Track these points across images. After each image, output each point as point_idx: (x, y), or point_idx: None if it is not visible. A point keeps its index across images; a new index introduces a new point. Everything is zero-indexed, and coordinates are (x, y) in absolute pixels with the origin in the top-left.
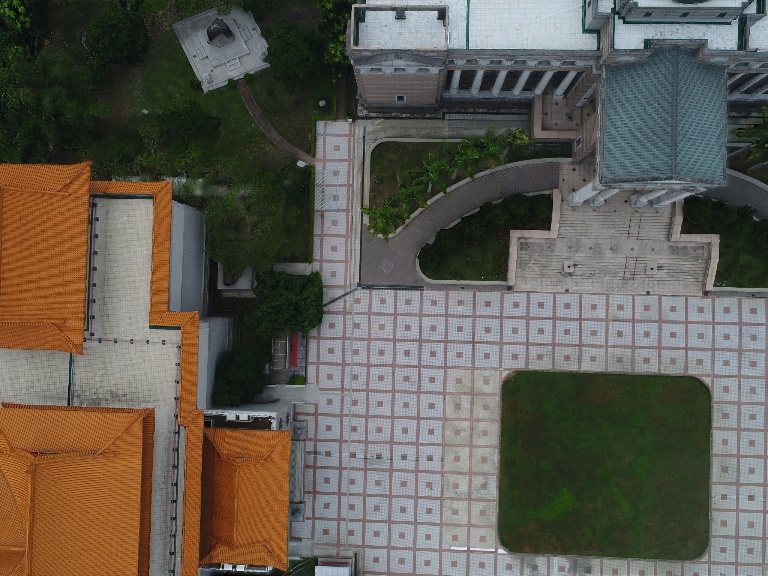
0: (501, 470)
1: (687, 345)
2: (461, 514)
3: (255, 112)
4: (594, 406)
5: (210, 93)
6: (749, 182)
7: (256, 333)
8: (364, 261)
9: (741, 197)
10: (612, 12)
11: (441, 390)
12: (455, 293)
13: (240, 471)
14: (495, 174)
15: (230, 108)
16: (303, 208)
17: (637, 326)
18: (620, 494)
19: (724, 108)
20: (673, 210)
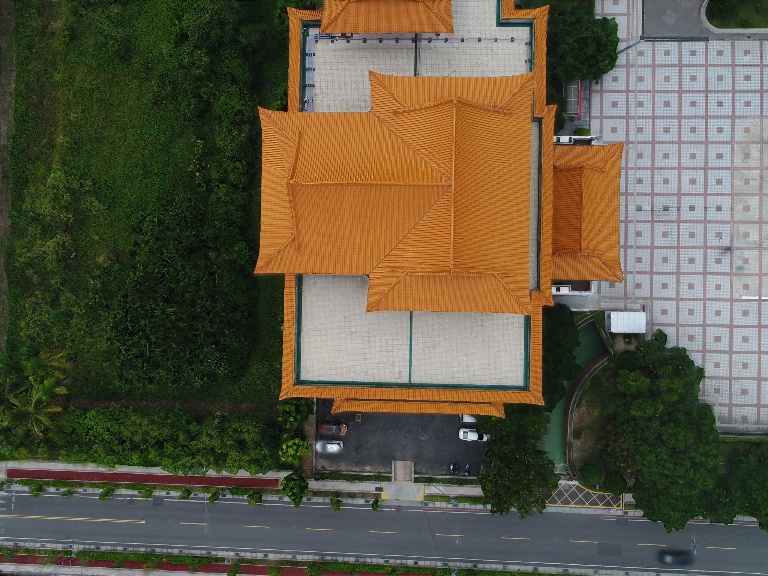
0: None
1: None
2: (752, 263)
3: None
4: None
5: None
6: None
7: (556, 72)
8: (647, 13)
9: None
10: None
11: (729, 140)
12: (741, 43)
13: (584, 174)
14: None
15: None
16: None
17: None
18: None
19: None
20: None
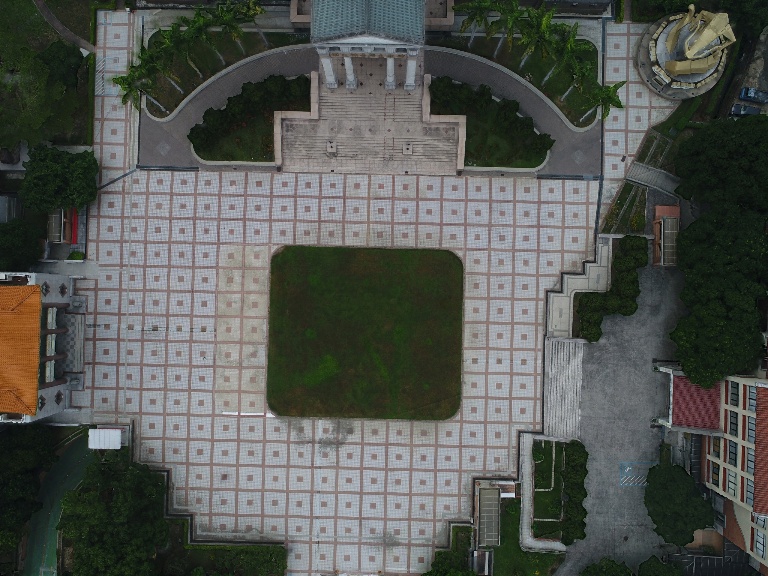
0: (270, 339)
1: (442, 221)
2: (232, 381)
3: (38, 2)
4: (356, 278)
5: None
6: (495, 68)
7: (26, 205)
8: (142, 144)
9: (488, 82)
10: None
11: (214, 265)
12: (228, 174)
13: None
14: (262, 60)
15: None
16: (84, 93)
17: (396, 203)
18: (379, 359)
19: None
20: (423, 92)
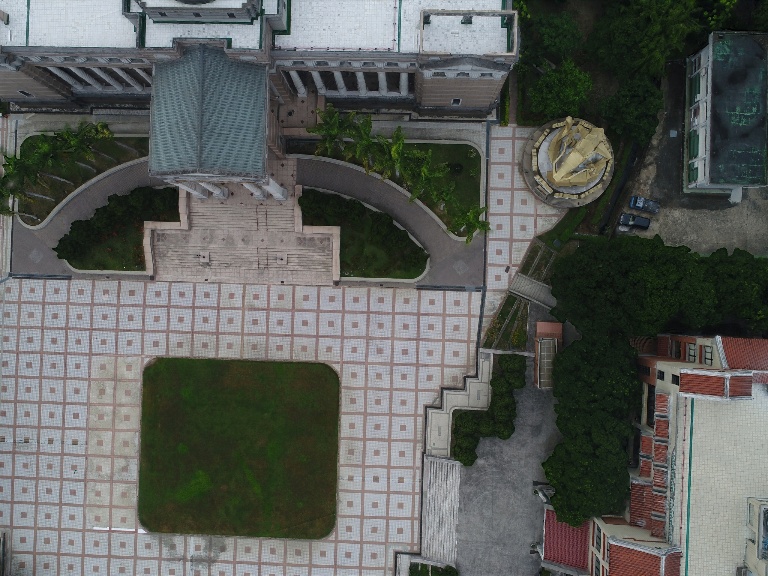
0: (141, 453)
1: (318, 333)
2: (103, 495)
3: None
4: (229, 391)
5: None
6: (372, 176)
7: None
8: (15, 251)
9: (365, 190)
10: (143, 12)
11: (86, 376)
12: (101, 282)
13: None
14: (132, 167)
15: None
16: None
17: (271, 315)
18: (252, 476)
19: (264, 104)
20: None
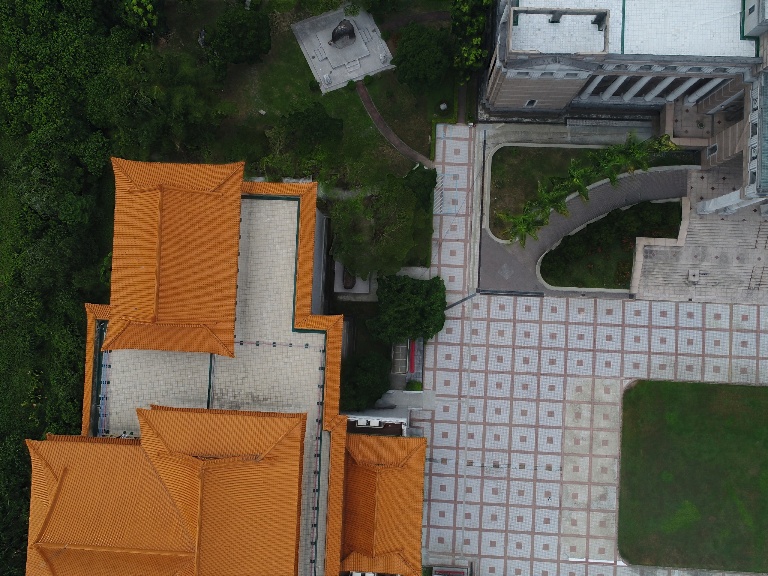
0: (621, 481)
1: None
2: (580, 525)
3: (374, 114)
4: (717, 417)
5: (328, 94)
6: None
7: (380, 338)
8: (483, 266)
9: None
10: None
11: (561, 398)
12: (576, 300)
13: (379, 478)
14: (620, 181)
15: (348, 110)
16: None
17: (762, 337)
18: (743, 507)
19: None
20: None
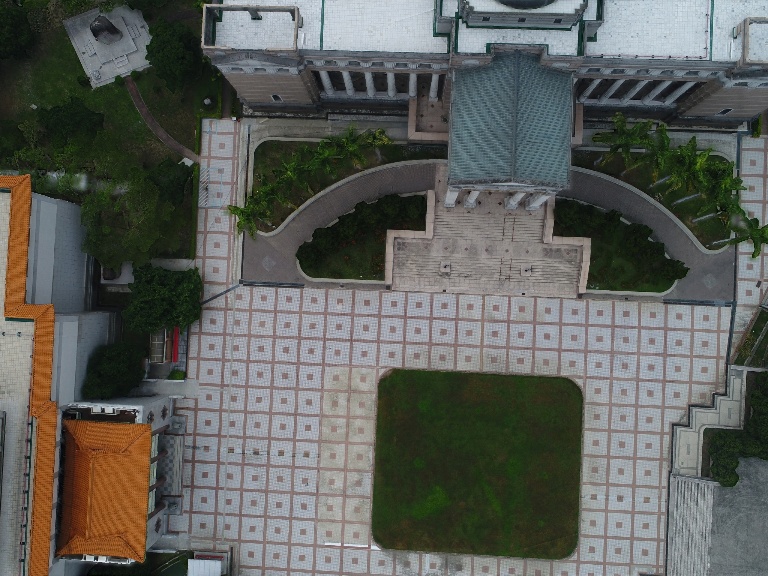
0: (376, 467)
1: (560, 346)
2: (336, 510)
3: (142, 109)
4: (468, 405)
5: (98, 89)
6: (622, 187)
7: (131, 327)
8: (246, 258)
9: (614, 201)
10: (456, 16)
11: (319, 387)
12: (335, 291)
13: (95, 463)
14: (374, 174)
15: (118, 105)
16: (187, 205)
17: (512, 327)
18: (492, 493)
19: (569, 113)
20: (545, 213)
